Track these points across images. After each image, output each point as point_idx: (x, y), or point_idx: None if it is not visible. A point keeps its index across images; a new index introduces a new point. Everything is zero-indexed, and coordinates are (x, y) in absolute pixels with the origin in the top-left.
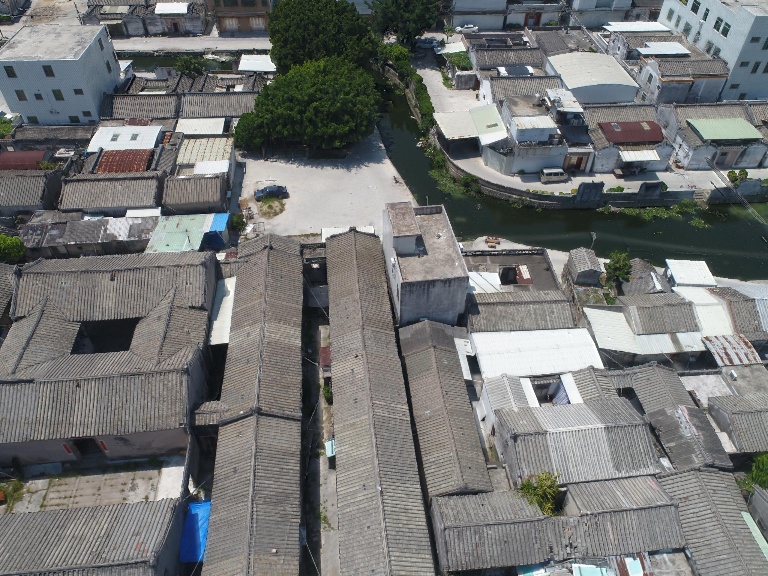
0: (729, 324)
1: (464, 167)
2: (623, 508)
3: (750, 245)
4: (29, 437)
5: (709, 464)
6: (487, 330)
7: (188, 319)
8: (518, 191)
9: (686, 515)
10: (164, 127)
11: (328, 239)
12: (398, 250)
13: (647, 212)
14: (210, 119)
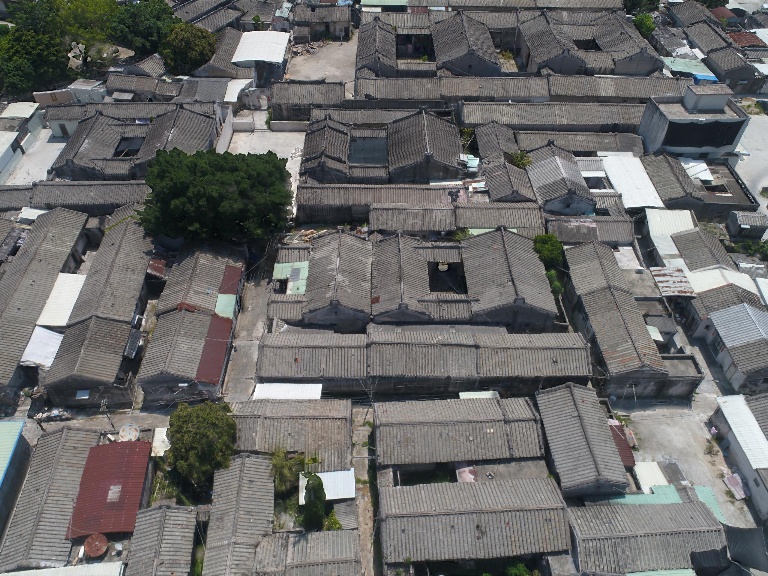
0: None
1: None
2: None
3: None
4: (525, 36)
5: None
6: (643, 162)
7: (605, 60)
8: None
9: None
10: None
11: None
12: None
13: None
14: None
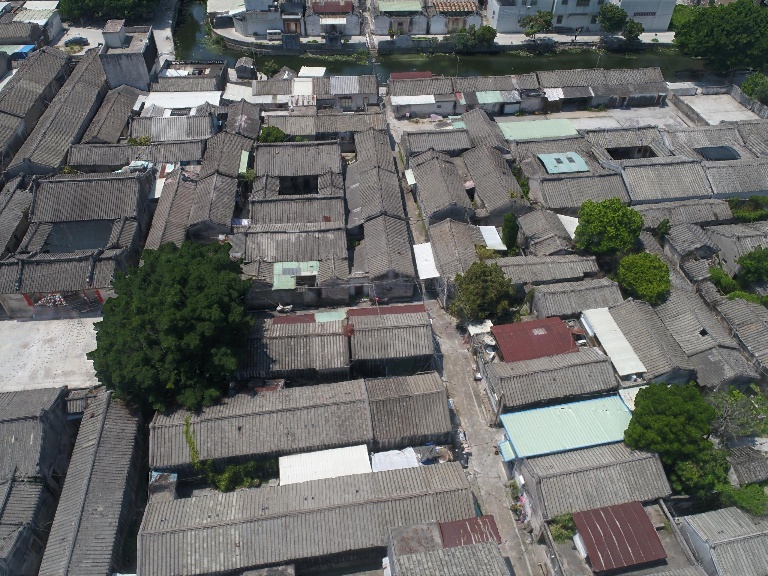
0: (311, 91)
1: (220, 32)
2: (172, 142)
3: (388, 73)
4: None
5: (236, 132)
6: (160, 91)
7: None
8: (246, 43)
9: (210, 149)
10: (15, 5)
11: (86, 52)
12: (109, 44)
13: (333, 57)
14: (49, 1)
